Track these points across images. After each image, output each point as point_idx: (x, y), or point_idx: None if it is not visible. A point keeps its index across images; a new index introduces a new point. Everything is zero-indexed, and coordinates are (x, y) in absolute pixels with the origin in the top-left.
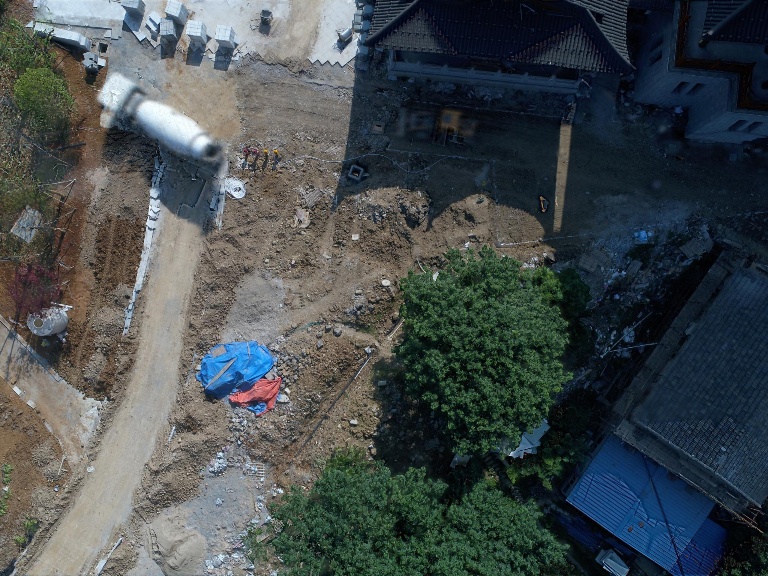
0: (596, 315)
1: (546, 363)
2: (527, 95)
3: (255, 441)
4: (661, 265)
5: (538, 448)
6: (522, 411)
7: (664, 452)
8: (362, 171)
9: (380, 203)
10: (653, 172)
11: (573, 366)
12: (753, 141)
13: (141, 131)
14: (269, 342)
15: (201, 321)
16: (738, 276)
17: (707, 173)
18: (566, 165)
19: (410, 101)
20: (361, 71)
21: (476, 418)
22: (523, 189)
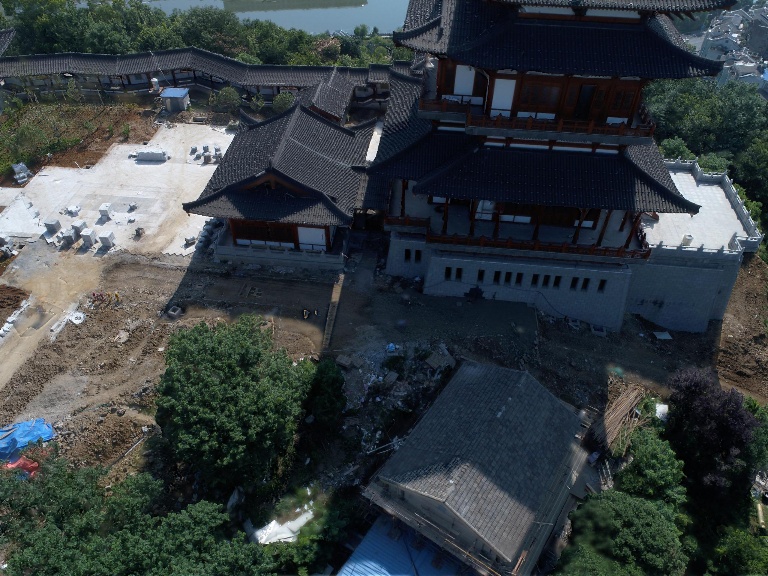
0: (361, 415)
1: (277, 386)
2: (311, 271)
3: (2, 508)
4: (415, 378)
5: (298, 535)
6: (242, 405)
7: (412, 512)
8: (180, 309)
9: (186, 324)
10: (400, 312)
11: (342, 462)
12: (470, 293)
13: (22, 287)
14: (56, 420)
15: (2, 404)
16: (465, 366)
17: (441, 312)
18: (336, 308)
19: (227, 274)
20: (196, 258)
21: (198, 407)
22: (302, 321)
